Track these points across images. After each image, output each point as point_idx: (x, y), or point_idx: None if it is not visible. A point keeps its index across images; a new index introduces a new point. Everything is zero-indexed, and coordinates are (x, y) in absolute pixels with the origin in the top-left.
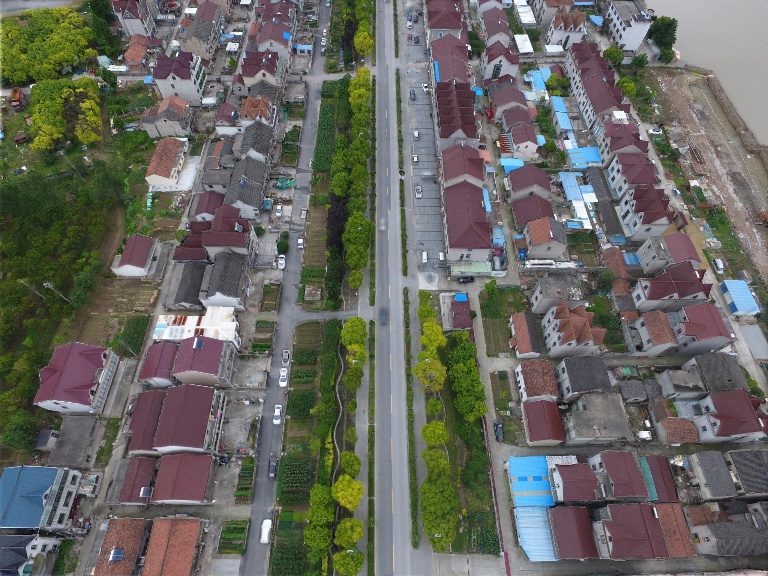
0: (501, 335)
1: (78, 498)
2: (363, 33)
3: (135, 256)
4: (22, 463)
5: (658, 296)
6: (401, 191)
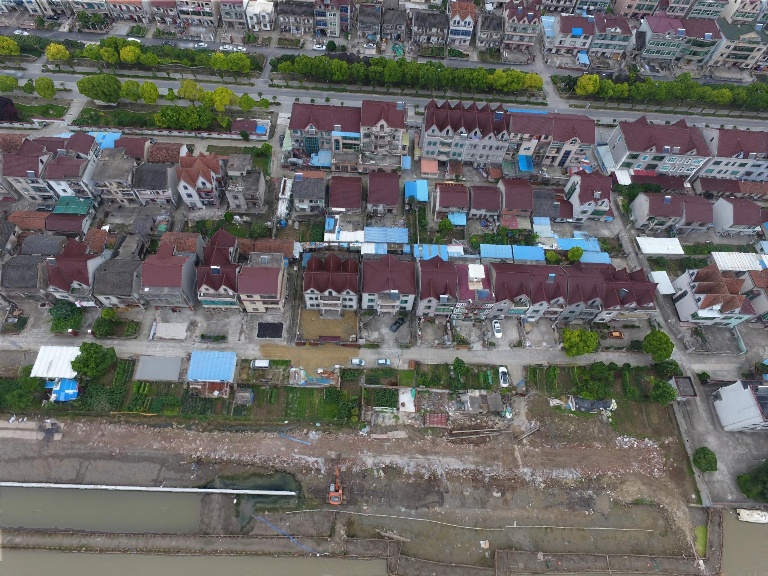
0: None
1: None
2: (596, 76)
3: None
4: None
5: None
6: None
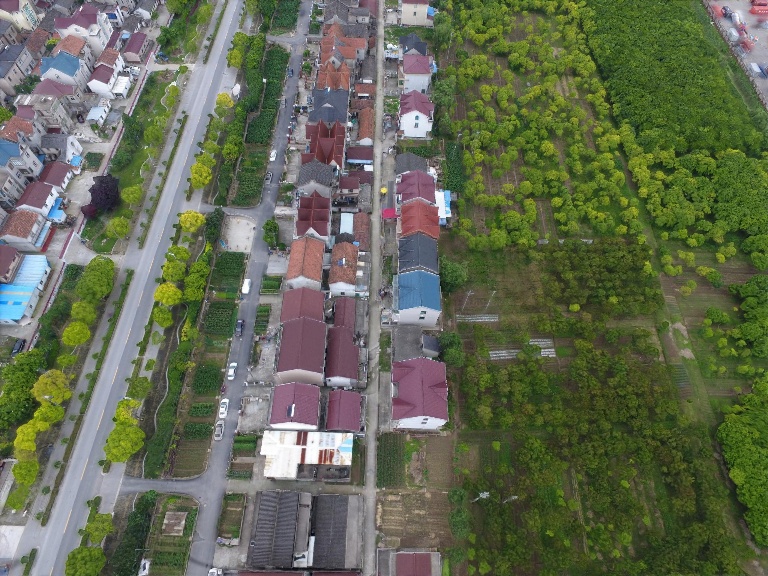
0: None
1: None
2: None
3: (410, 572)
4: None
5: None
6: None
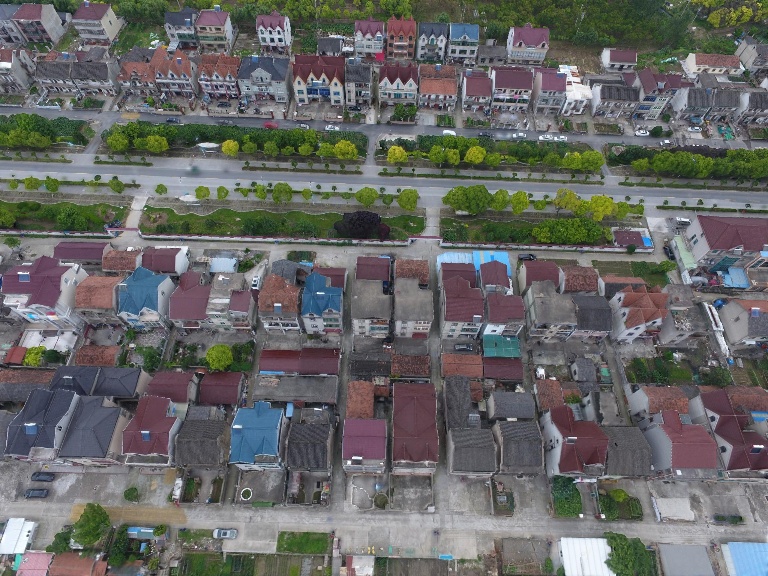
0: (617, 274)
1: (462, 62)
2: None
3: (618, 54)
4: (478, 43)
5: (709, 405)
6: (759, 210)
